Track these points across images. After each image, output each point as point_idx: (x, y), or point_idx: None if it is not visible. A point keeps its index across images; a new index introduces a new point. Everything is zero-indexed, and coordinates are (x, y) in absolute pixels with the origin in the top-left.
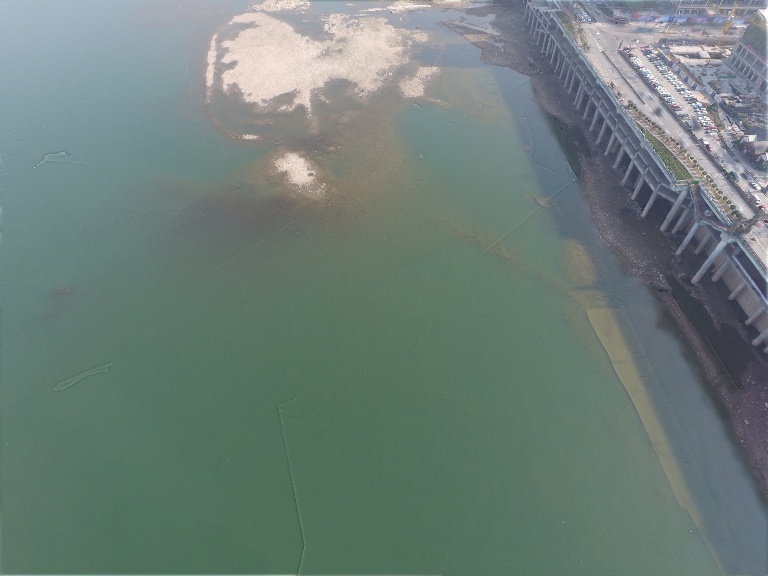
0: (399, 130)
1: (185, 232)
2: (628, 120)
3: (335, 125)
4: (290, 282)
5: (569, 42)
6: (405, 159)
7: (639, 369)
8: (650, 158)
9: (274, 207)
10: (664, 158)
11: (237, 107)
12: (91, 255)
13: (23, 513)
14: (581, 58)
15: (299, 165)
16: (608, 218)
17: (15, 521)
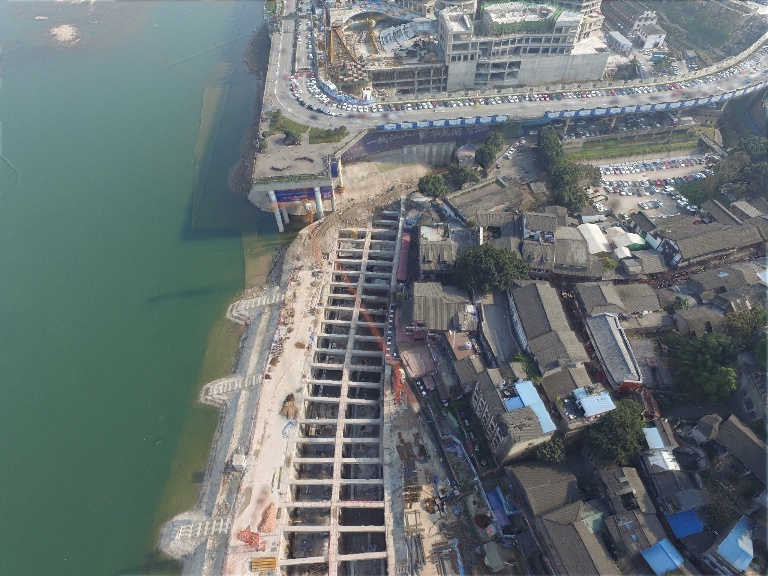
0: (150, 13)
1: None
2: None
3: (106, 11)
4: (33, 86)
5: None
6: (143, 27)
7: (215, 109)
8: None
9: (38, 51)
10: (268, 3)
11: (40, 2)
12: None
13: None
14: None
15: (67, 31)
16: (252, 49)
17: None
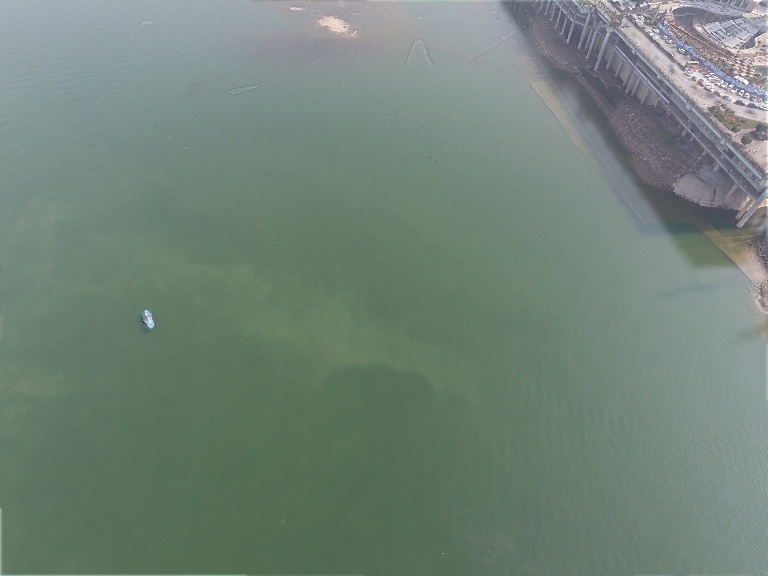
0: (403, 5)
1: (266, 55)
2: None
3: (356, 2)
4: (343, 78)
5: None
6: (410, 19)
7: (560, 103)
8: (570, 2)
9: (324, 42)
10: None
11: None
12: (209, 62)
13: (213, 165)
14: None
15: (336, 22)
16: (545, 43)
17: (211, 167)
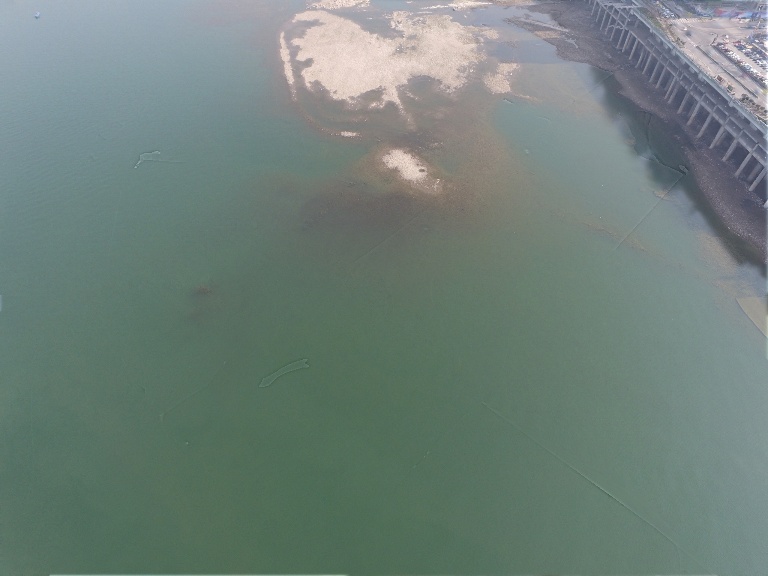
0: (497, 126)
1: (312, 229)
2: (746, 113)
3: (431, 121)
4: (430, 277)
5: (655, 38)
6: (512, 154)
7: None
8: None
9: (395, 203)
10: None
11: (326, 104)
12: (227, 253)
13: (229, 511)
14: (676, 53)
15: (408, 161)
16: (732, 209)
17: (224, 519)
